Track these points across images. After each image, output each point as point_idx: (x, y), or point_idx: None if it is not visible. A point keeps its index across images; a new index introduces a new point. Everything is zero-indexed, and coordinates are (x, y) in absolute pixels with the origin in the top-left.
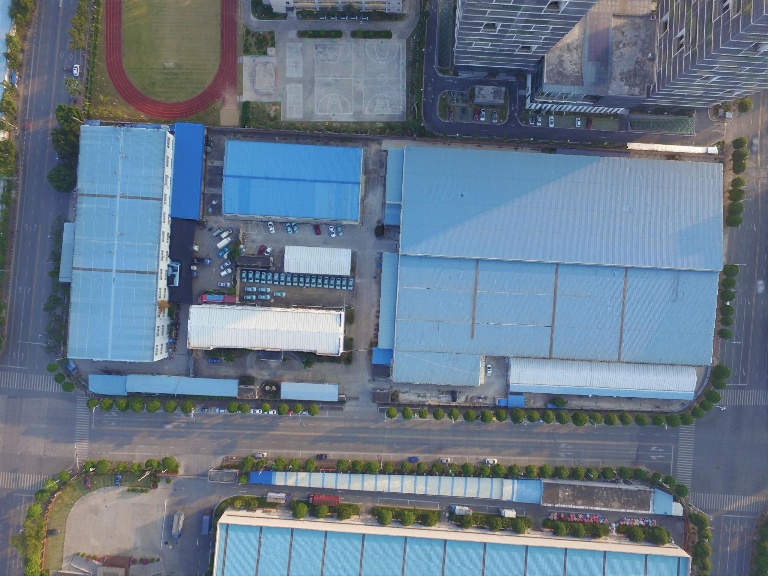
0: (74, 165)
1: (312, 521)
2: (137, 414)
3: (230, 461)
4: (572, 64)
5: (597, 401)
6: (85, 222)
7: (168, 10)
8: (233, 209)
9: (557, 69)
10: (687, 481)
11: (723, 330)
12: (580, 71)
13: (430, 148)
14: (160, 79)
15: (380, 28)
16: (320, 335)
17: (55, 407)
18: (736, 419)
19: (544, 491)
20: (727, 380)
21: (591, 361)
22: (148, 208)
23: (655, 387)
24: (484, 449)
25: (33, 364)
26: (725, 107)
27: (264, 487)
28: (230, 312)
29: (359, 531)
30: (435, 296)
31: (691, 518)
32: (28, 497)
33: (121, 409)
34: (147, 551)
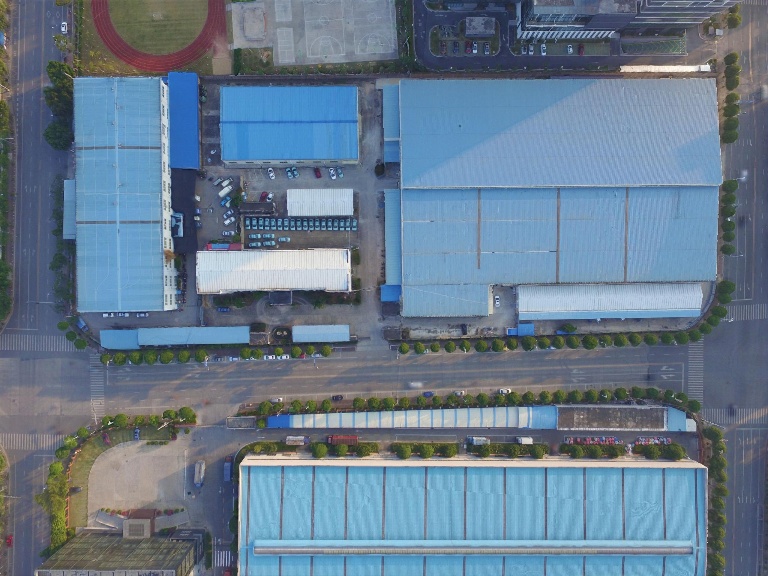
0: (69, 123)
1: (332, 459)
2: (151, 368)
3: (247, 408)
4: None
5: (606, 325)
6: (85, 175)
7: None
8: (232, 155)
9: None
10: (699, 398)
11: (726, 245)
12: None
13: (425, 81)
14: (149, 32)
15: None
16: (328, 272)
17: (68, 366)
18: (743, 334)
19: (559, 416)
20: (732, 296)
21: (598, 283)
22: (147, 157)
23: (662, 306)
24: (497, 380)
25: (43, 325)
26: (715, 25)
27: (282, 432)
28: (237, 255)
29: (380, 464)
30: (439, 228)
31: (705, 432)
32: (48, 457)
33: (135, 362)
34: (171, 502)
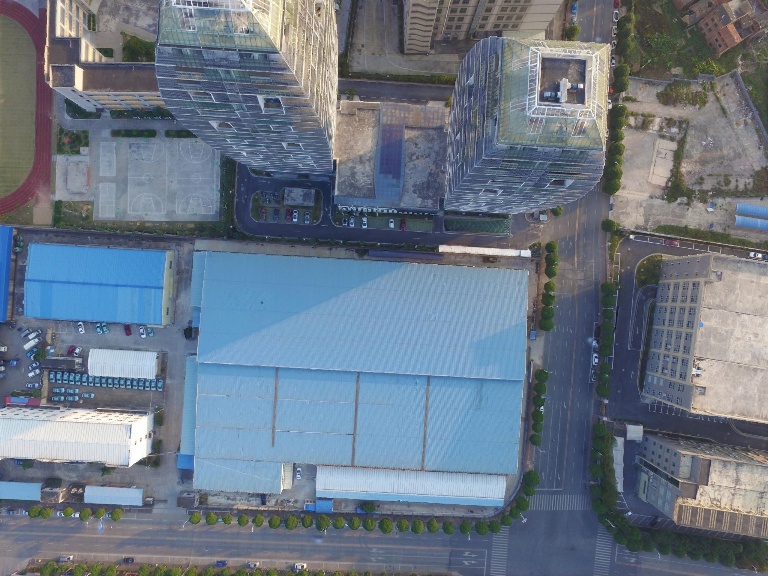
0: None
1: None
2: None
3: (36, 564)
4: (364, 176)
5: (410, 505)
6: None
7: None
8: (35, 313)
9: (349, 181)
10: None
11: (533, 436)
12: (372, 183)
13: (232, 254)
14: None
15: None
16: (109, 447)
17: None
18: (551, 524)
19: None
20: (542, 484)
21: (394, 469)
22: None
23: (464, 494)
24: (294, 553)
25: None
26: None
27: None
28: (19, 423)
29: None
30: (235, 403)
31: None
32: None
33: None
34: None
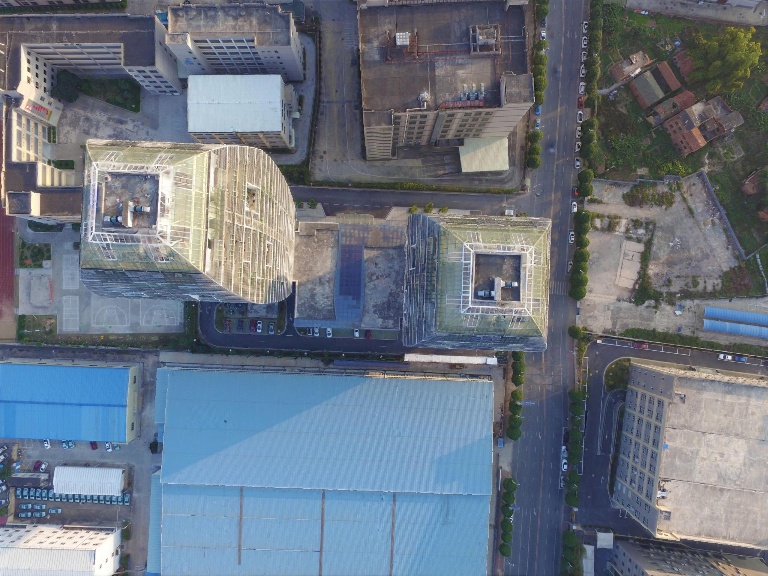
0: None
1: None
2: None
3: None
4: (324, 297)
5: None
6: None
7: None
8: None
9: (309, 303)
10: None
11: (502, 547)
12: (332, 304)
13: (194, 372)
14: None
15: None
16: (73, 573)
17: None
18: None
19: None
20: None
21: None
22: None
23: None
24: None
25: None
26: None
27: None
28: None
29: None
30: (200, 523)
31: None
32: None
33: None
34: None
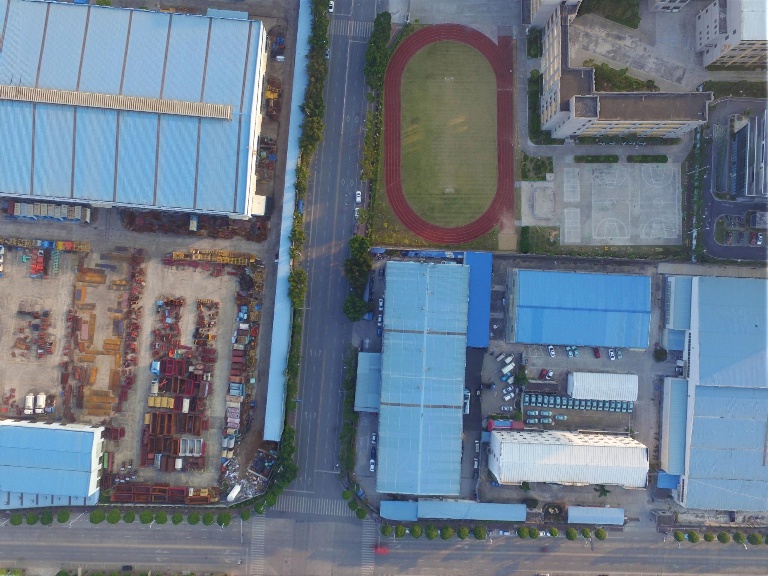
0: (362, 293)
1: None
2: (422, 537)
3: None
4: None
5: None
6: (392, 358)
7: (446, 136)
8: (525, 338)
9: None
10: None
11: None
12: None
13: (722, 278)
14: (439, 204)
15: (655, 152)
16: (628, 469)
17: (342, 531)
18: None
19: None
20: None
21: None
22: (454, 343)
23: None
24: (761, 568)
25: (320, 488)
26: None
27: None
28: (539, 447)
29: None
30: (728, 425)
31: None
32: None
33: (417, 537)
34: None
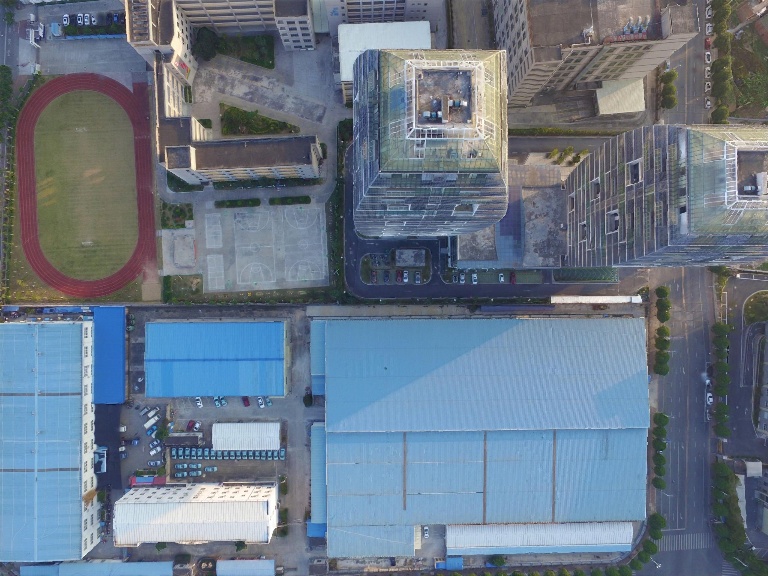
0: None
1: None
2: None
3: None
4: (485, 239)
5: (537, 555)
6: (4, 422)
7: (83, 187)
8: (157, 393)
9: (470, 244)
10: None
11: (656, 480)
12: (493, 245)
13: (351, 321)
14: (79, 258)
15: (298, 193)
16: (248, 524)
17: None
18: (676, 564)
19: None
20: (665, 526)
21: (525, 524)
22: (67, 404)
23: (592, 541)
24: None
25: None
26: None
27: None
28: (155, 507)
29: None
30: (364, 470)
31: None
32: None
33: None
34: None
